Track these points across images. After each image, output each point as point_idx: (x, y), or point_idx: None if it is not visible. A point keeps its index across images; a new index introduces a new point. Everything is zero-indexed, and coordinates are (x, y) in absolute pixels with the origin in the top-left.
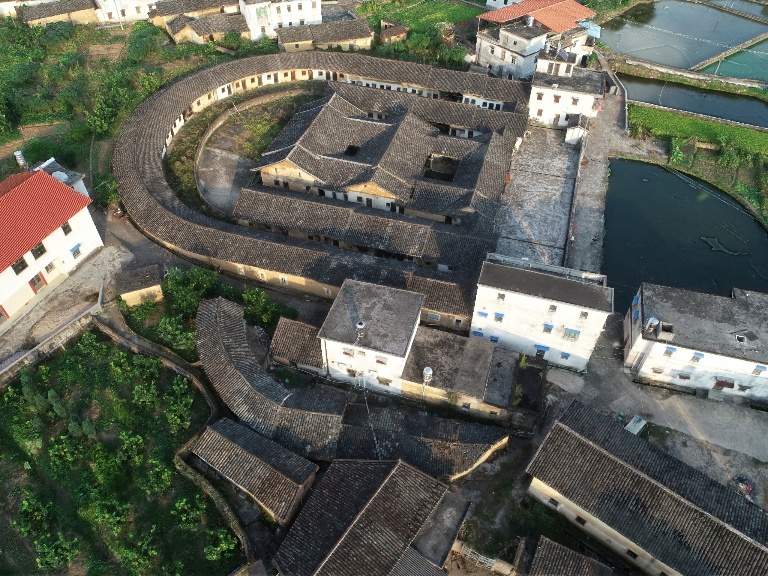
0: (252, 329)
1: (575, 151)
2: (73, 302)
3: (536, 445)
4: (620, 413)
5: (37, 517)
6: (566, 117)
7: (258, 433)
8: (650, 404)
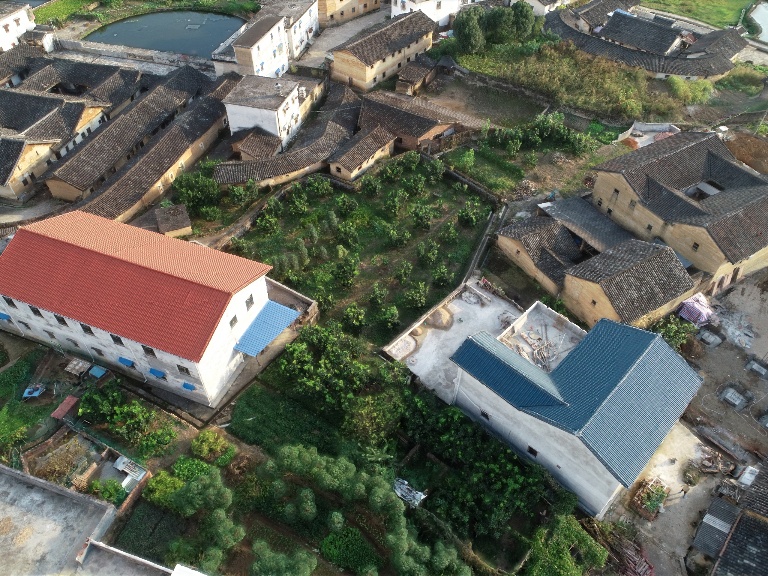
0: None
1: (63, 51)
2: None
3: None
4: (319, 66)
5: (397, 236)
6: (18, 42)
7: None
8: (313, 59)
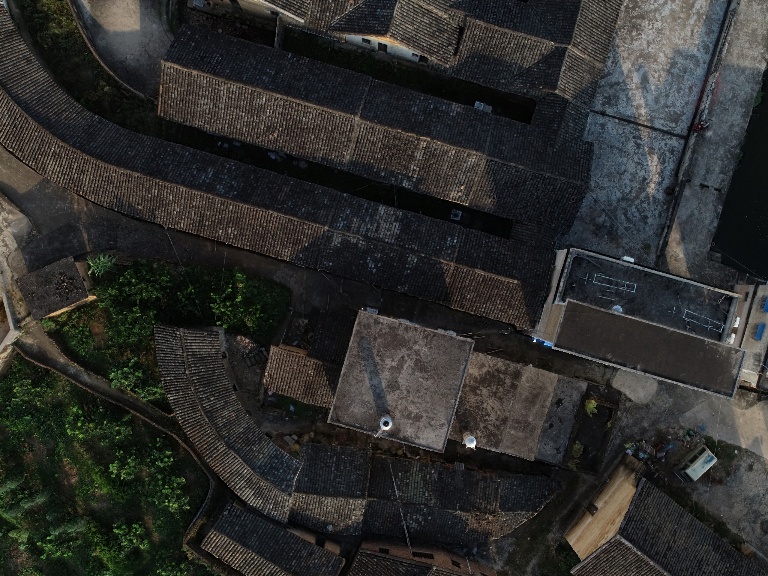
0: (234, 341)
1: None
2: None
3: (583, 478)
4: (690, 432)
5: None
6: None
7: (271, 519)
8: (729, 415)
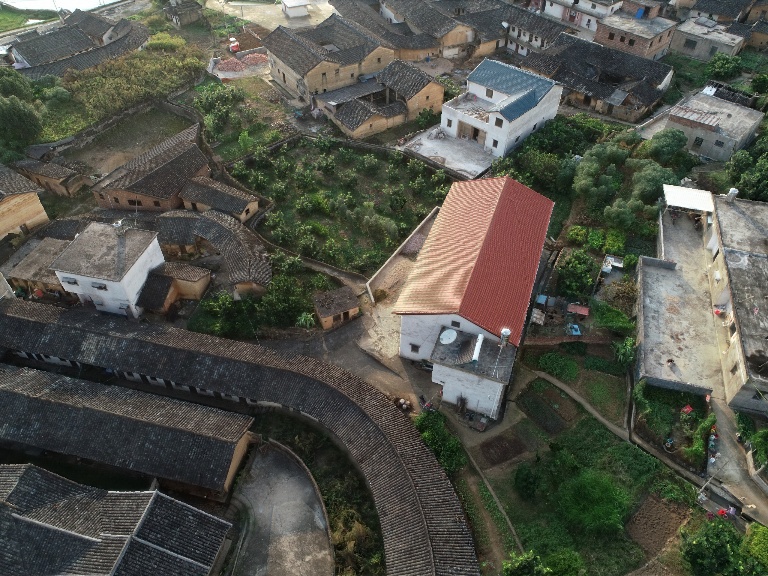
0: None
1: None
2: (396, 291)
3: None
4: None
5: None
6: None
7: None
8: None
